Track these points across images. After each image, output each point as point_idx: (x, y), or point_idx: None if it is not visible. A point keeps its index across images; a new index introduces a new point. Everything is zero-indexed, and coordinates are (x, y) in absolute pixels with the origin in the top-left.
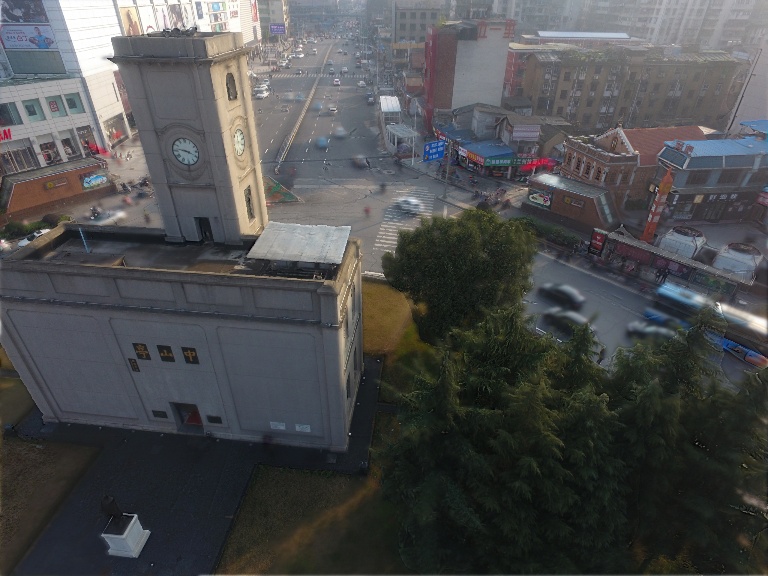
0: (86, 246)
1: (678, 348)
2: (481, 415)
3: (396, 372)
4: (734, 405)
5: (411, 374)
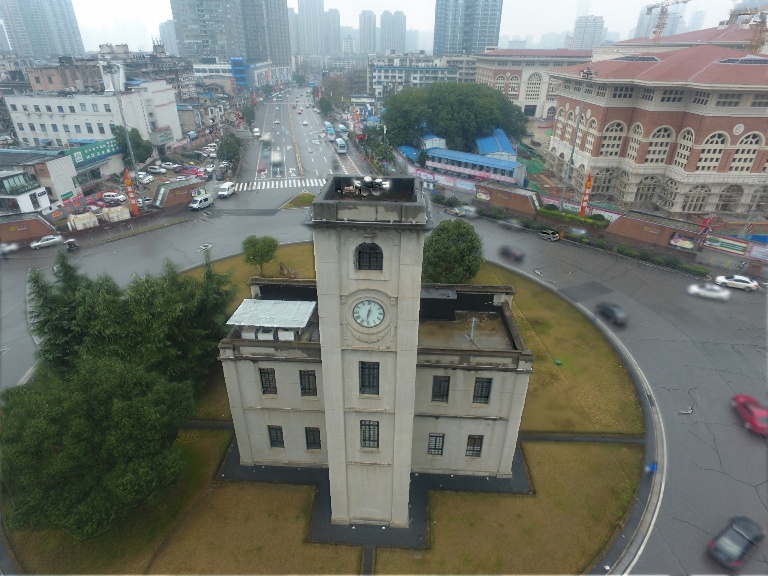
0: (472, 333)
1: (48, 303)
2: (195, 280)
3: (210, 459)
4: (72, 278)
5: (195, 457)
